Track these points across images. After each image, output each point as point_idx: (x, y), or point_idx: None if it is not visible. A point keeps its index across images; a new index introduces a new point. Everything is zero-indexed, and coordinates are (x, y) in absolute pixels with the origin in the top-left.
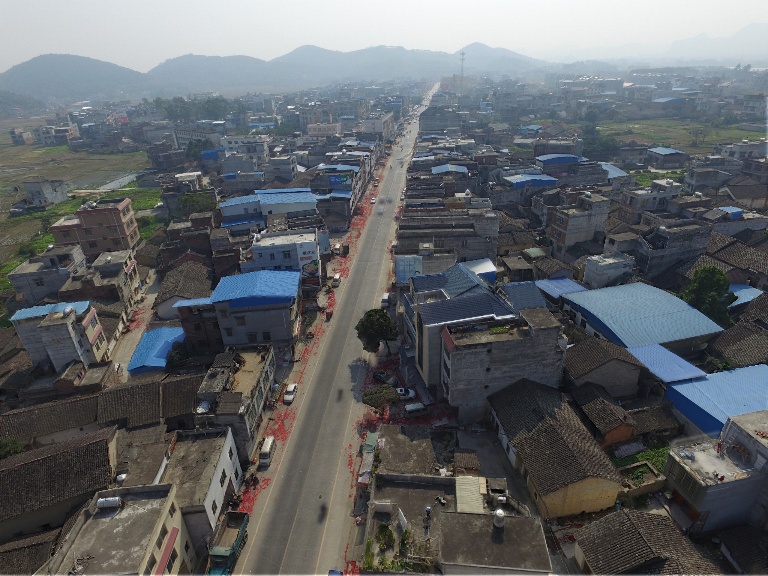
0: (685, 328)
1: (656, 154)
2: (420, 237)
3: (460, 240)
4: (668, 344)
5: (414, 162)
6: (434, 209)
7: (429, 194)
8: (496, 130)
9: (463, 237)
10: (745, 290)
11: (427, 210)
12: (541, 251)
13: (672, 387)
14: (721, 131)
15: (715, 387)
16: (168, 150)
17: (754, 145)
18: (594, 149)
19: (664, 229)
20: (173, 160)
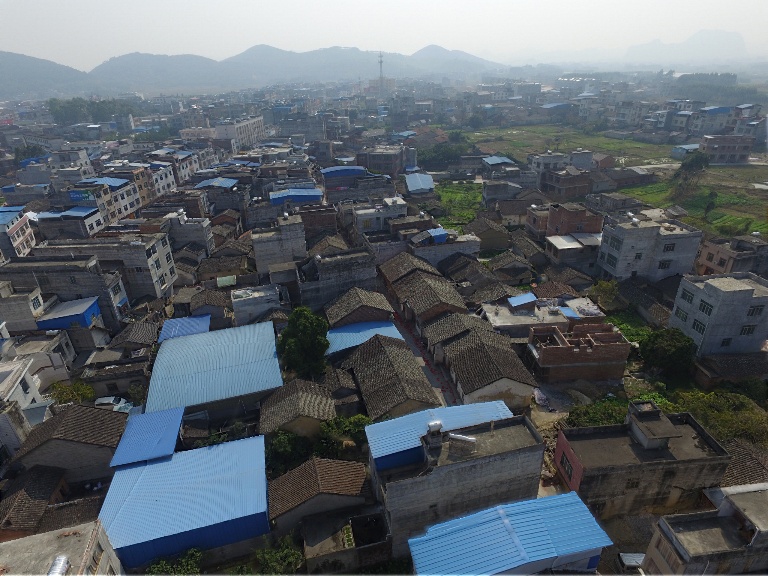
0: (239, 384)
1: (487, 164)
2: (18, 272)
3: (66, 275)
4: (203, 406)
5: (193, 174)
6: (127, 232)
7: (166, 212)
8: (371, 136)
9: (68, 272)
10: (372, 330)
11: (120, 233)
12: (233, 279)
13: (114, 473)
14: (587, 138)
15: (162, 472)
16: (0, 157)
17: (558, 156)
18: (434, 158)
19: (318, 259)
20: (6, 168)
